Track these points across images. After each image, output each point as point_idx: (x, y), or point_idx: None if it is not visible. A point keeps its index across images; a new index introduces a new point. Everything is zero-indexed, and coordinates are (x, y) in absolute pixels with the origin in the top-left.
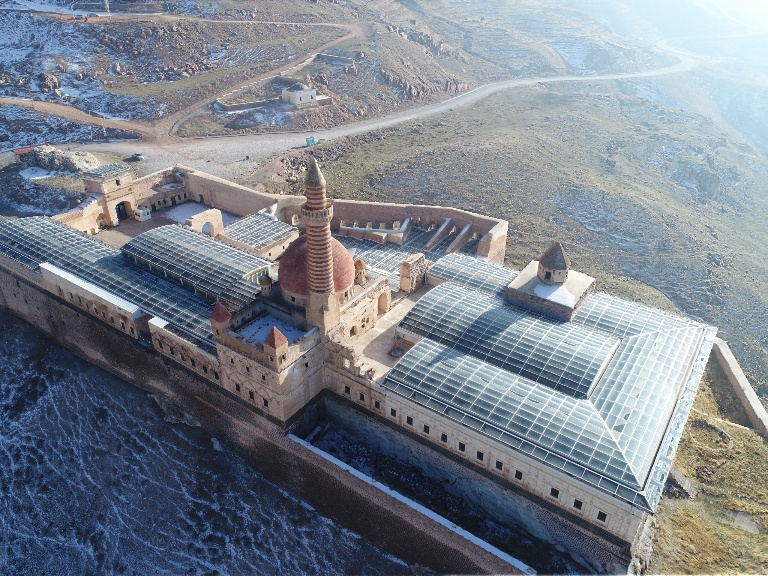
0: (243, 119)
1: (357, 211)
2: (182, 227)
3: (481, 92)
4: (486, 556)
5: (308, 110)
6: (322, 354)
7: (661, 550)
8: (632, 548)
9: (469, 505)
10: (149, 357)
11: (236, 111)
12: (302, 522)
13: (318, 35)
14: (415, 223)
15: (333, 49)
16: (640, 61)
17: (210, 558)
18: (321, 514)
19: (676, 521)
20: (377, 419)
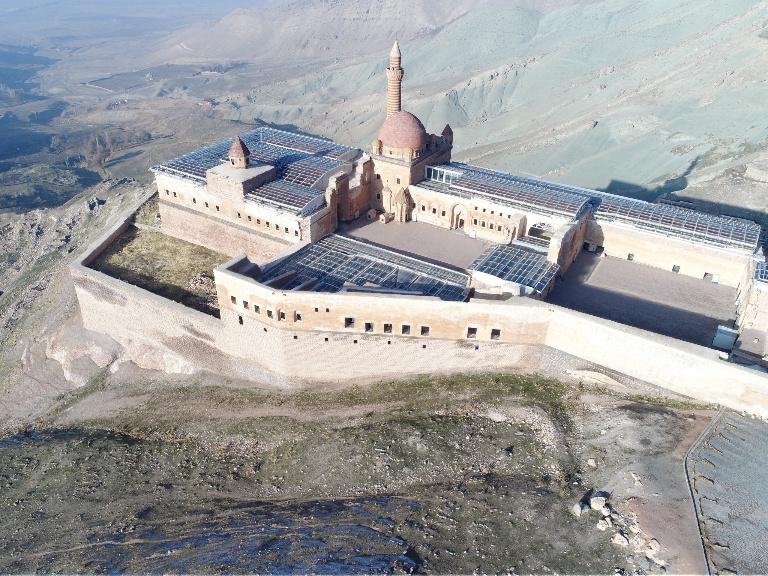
0: None
1: None
2: (563, 214)
3: None
4: None
5: None
6: None
7: None
8: None
9: None
10: None
11: None
12: None
13: None
14: None
15: None
16: None
17: None
18: None
19: None
20: None
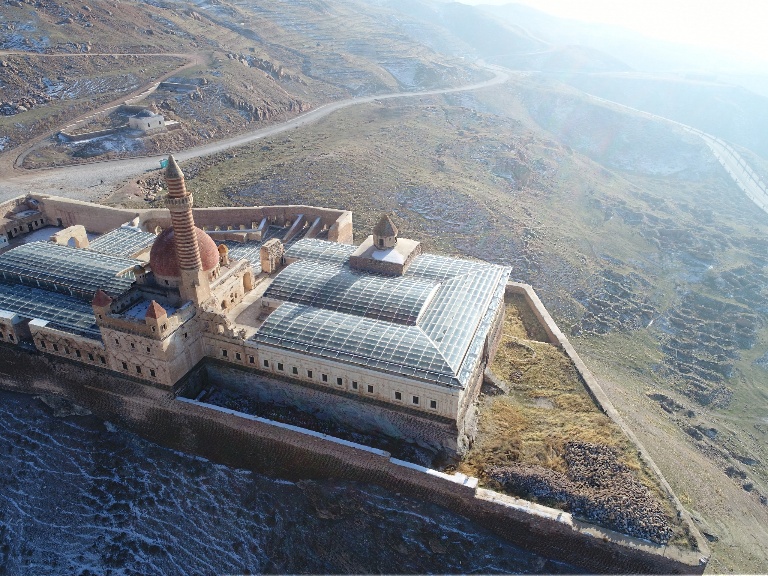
0: (91, 148)
1: (217, 217)
2: (47, 243)
3: (323, 111)
4: (352, 452)
5: (158, 135)
6: (198, 325)
7: (484, 429)
8: (458, 424)
9: (337, 425)
10: (32, 359)
11: (83, 141)
12: (199, 473)
13: (159, 65)
14: (272, 222)
15: (176, 77)
16: (462, 77)
17: (117, 523)
18: (215, 463)
19: (494, 409)
20: (253, 372)
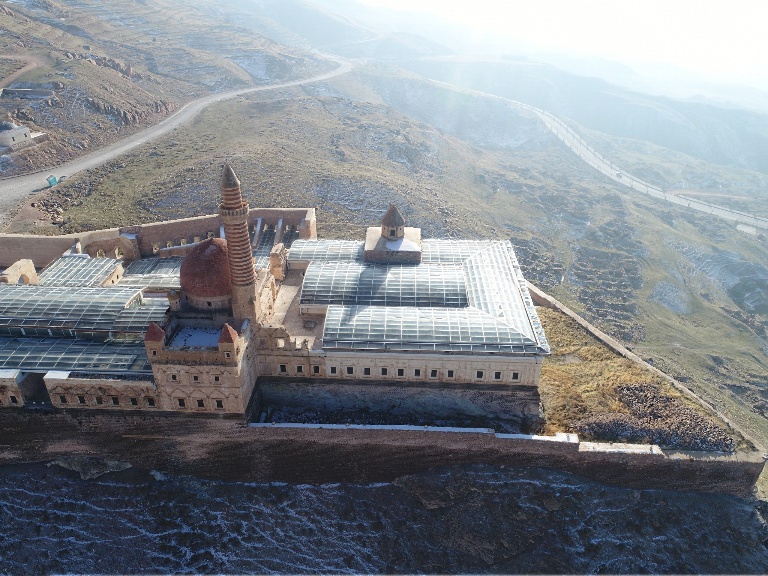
0: None
1: (169, 231)
2: (2, 284)
3: (191, 110)
4: (456, 437)
5: (26, 150)
6: (254, 344)
7: (543, 391)
8: (537, 390)
9: (417, 416)
10: (46, 419)
11: None
12: (281, 499)
13: None
14: None
15: (20, 82)
16: (310, 67)
17: (202, 575)
18: (295, 484)
19: None
20: (319, 382)
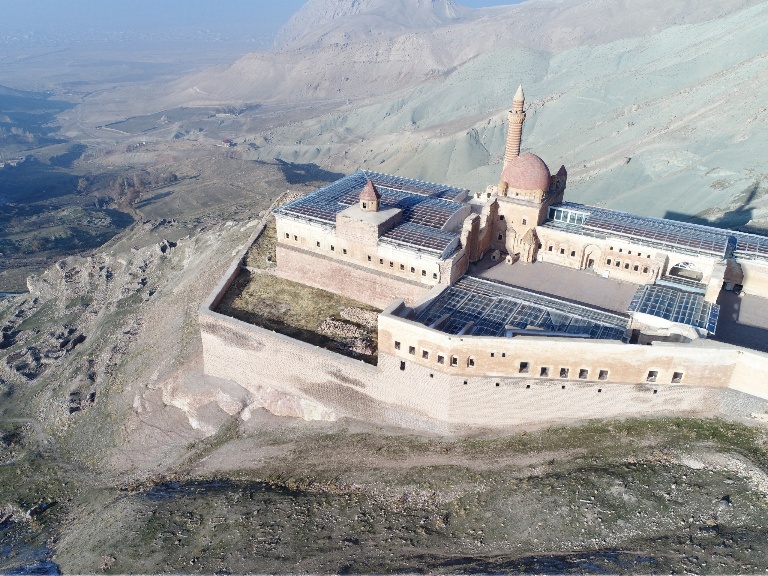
0: None
1: None
2: (711, 254)
3: None
4: None
5: None
6: None
7: None
8: None
9: None
10: None
11: None
12: None
13: None
14: None
15: None
16: None
17: None
18: None
19: None
20: None
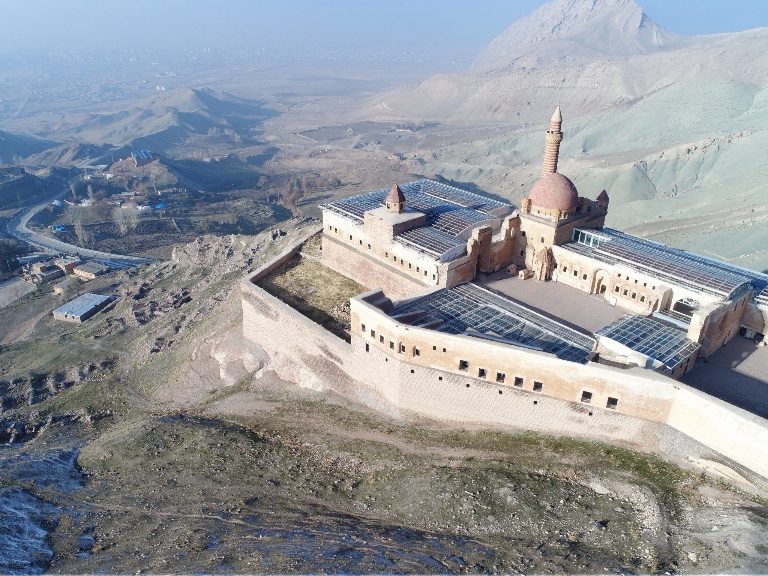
0: None
1: None
2: (714, 292)
3: None
4: None
5: None
6: None
7: None
8: None
9: None
10: None
11: None
12: None
13: None
14: None
15: None
16: None
17: None
18: None
19: None
20: None
